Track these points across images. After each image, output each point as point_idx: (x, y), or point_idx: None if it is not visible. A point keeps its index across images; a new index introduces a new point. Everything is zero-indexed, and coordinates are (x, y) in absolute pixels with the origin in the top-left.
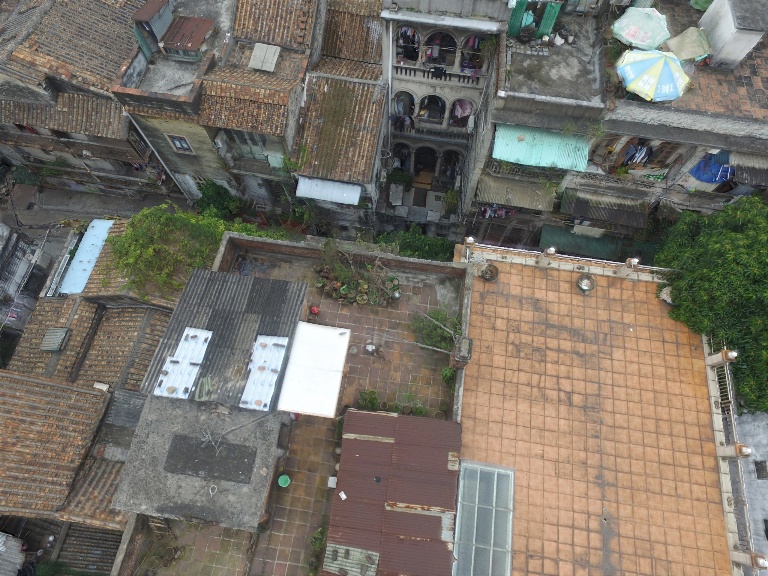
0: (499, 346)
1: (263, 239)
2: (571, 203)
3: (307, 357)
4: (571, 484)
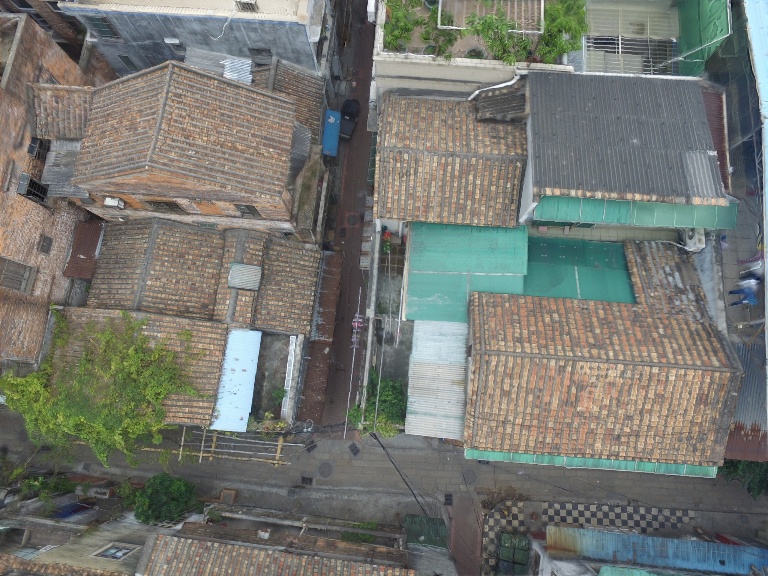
0: None
1: None
2: None
3: None
4: None
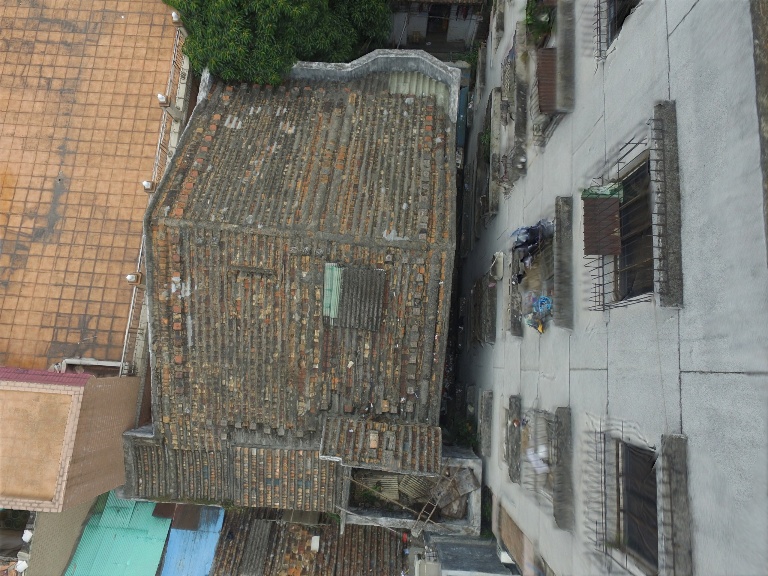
0: None
1: None
2: None
3: None
4: (34, 155)
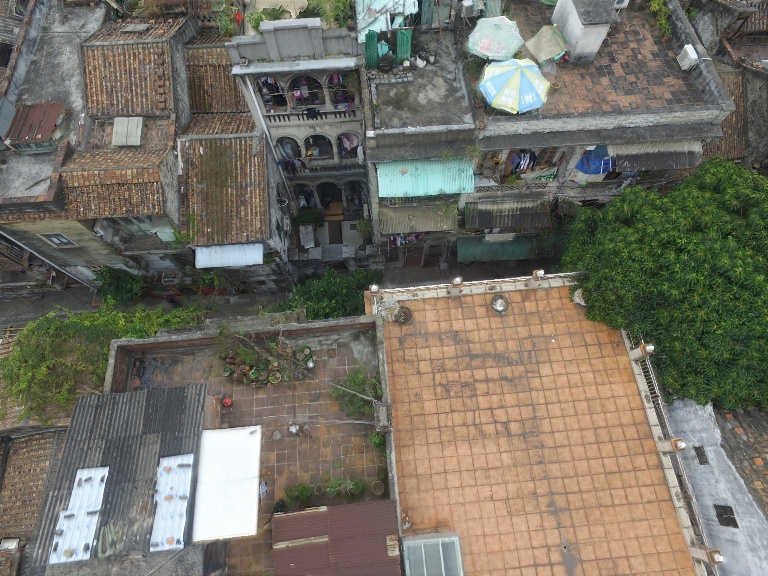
0: (427, 391)
1: (155, 339)
2: (474, 217)
3: (218, 470)
4: (525, 519)
